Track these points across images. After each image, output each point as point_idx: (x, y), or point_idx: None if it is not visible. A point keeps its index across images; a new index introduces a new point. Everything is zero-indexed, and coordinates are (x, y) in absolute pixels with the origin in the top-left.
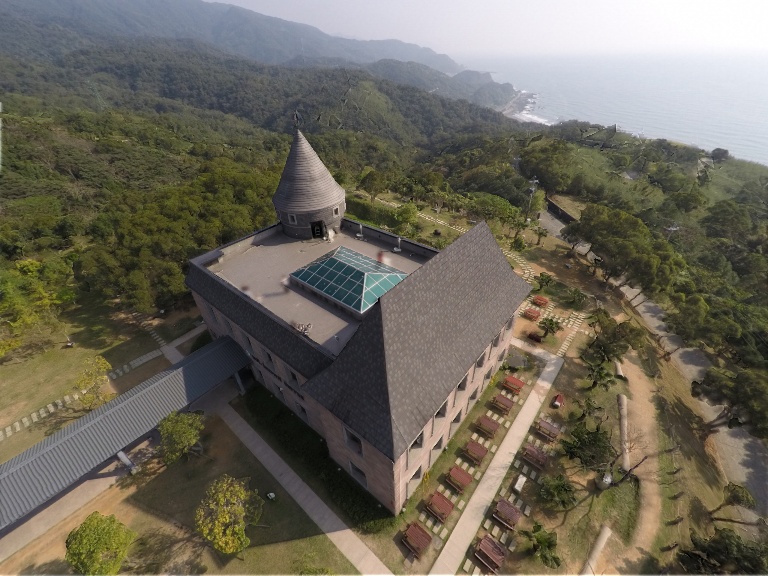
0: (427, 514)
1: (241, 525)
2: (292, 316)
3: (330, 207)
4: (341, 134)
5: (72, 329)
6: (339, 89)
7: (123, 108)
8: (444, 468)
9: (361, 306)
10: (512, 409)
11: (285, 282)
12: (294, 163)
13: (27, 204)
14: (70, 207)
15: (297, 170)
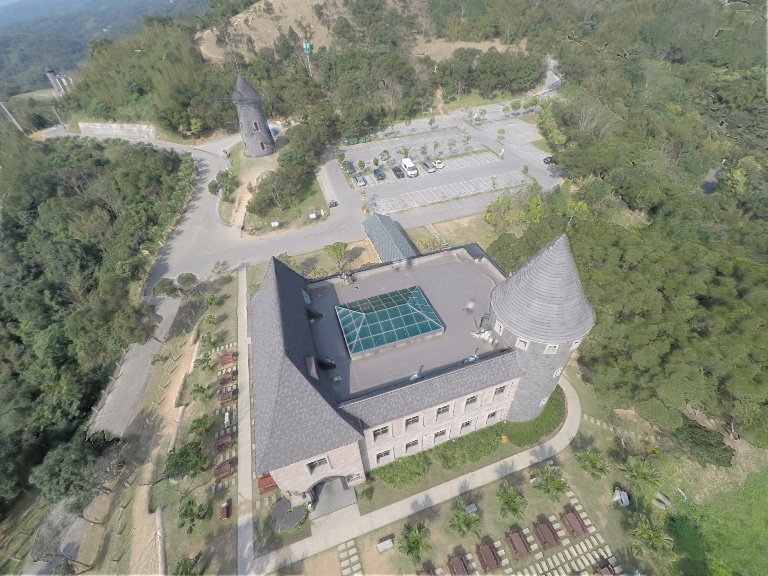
0: None
1: None
2: (373, 283)
3: None
4: None
5: None
6: None
7: None
8: None
9: (340, 307)
10: None
11: None
12: None
13: None
14: None
15: None
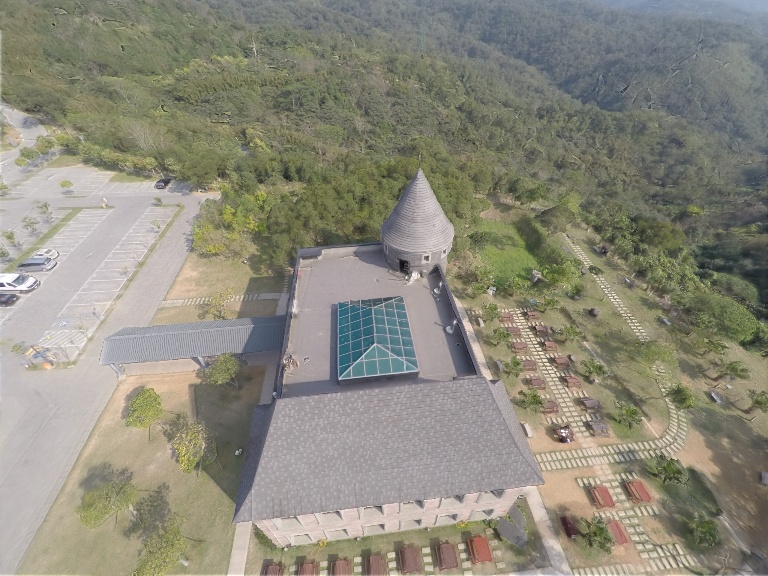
0: (297, 570)
1: (196, 459)
2: (306, 342)
3: (420, 253)
4: (640, 116)
5: (255, 251)
6: (677, 54)
7: (434, 52)
8: (342, 552)
9: (344, 372)
10: (451, 570)
11: (335, 306)
12: (405, 199)
13: (324, 130)
14: (347, 138)
15: (404, 207)
